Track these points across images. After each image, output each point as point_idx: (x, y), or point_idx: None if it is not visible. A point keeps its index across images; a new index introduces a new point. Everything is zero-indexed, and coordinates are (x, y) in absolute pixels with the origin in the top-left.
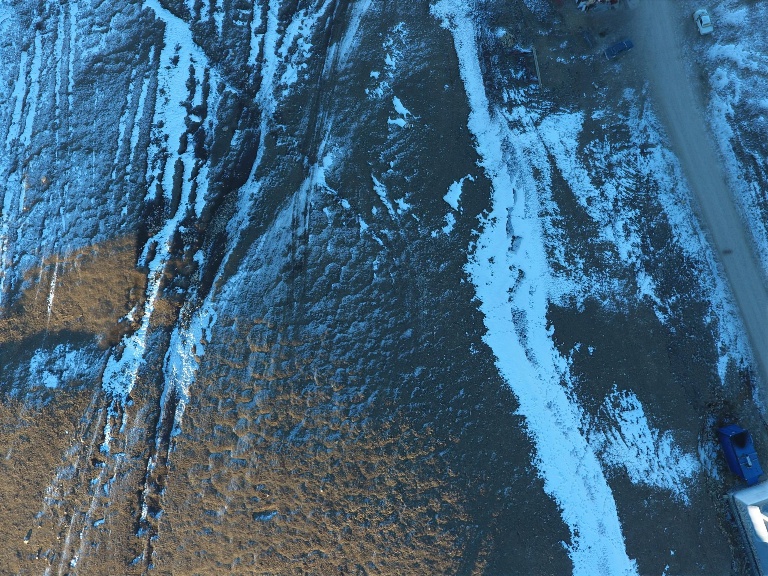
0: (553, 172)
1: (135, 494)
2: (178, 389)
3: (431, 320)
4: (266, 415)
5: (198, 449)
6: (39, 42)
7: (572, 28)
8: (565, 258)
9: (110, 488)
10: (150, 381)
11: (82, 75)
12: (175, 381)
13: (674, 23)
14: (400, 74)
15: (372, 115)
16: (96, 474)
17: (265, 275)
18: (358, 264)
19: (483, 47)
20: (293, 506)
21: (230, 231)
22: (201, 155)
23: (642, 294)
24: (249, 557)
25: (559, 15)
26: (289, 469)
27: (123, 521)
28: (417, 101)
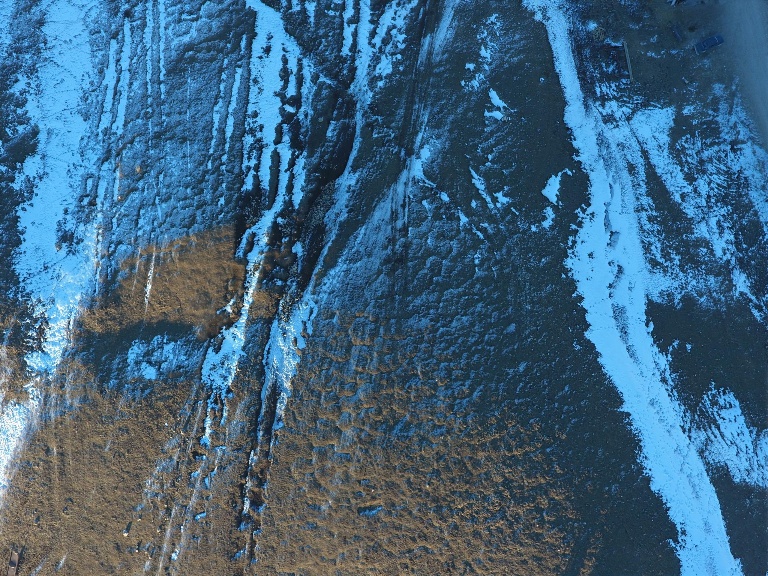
0: (647, 167)
1: (237, 487)
2: (279, 382)
3: (534, 315)
4: (370, 409)
5: (301, 443)
6: (128, 30)
7: (661, 22)
8: (661, 254)
9: (211, 481)
10: (251, 373)
11: (173, 64)
12: (276, 374)
13: (764, 18)
14: (495, 66)
15: (469, 107)
16: (197, 467)
17: (365, 268)
18: (459, 258)
19: (575, 40)
20: (399, 501)
21: (328, 223)
22: (297, 146)
23: (738, 291)
24: (354, 552)
25: (648, 9)
26: (394, 464)
27: (225, 515)
28: (513, 94)
